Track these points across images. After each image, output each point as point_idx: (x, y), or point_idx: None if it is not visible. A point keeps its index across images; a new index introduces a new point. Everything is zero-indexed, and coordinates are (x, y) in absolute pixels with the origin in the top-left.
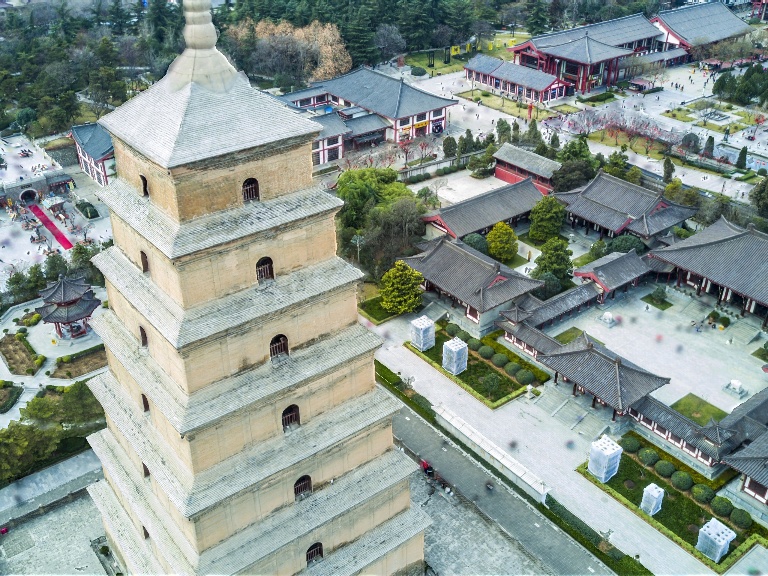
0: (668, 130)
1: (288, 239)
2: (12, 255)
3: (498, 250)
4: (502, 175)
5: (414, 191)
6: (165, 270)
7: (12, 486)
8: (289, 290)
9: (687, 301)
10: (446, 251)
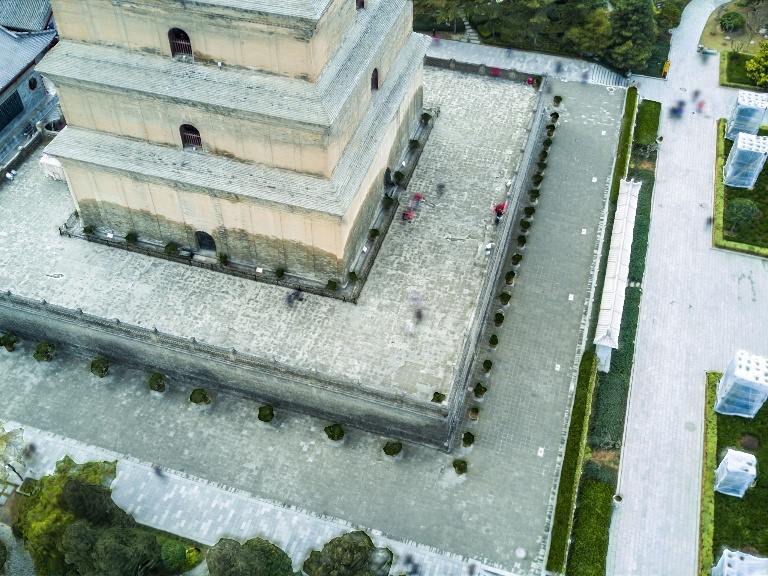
0: None
1: None
2: None
3: None
4: None
5: None
6: None
7: None
8: None
9: None
10: None
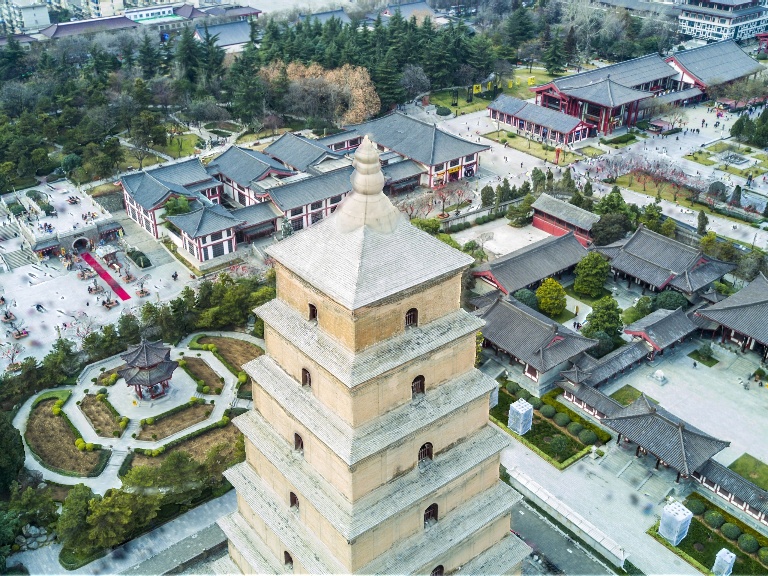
0: (692, 174)
1: (439, 358)
2: (72, 306)
3: (548, 306)
4: (540, 224)
5: (458, 242)
6: (334, 391)
7: (116, 552)
8: (438, 403)
9: (732, 358)
10: (502, 310)
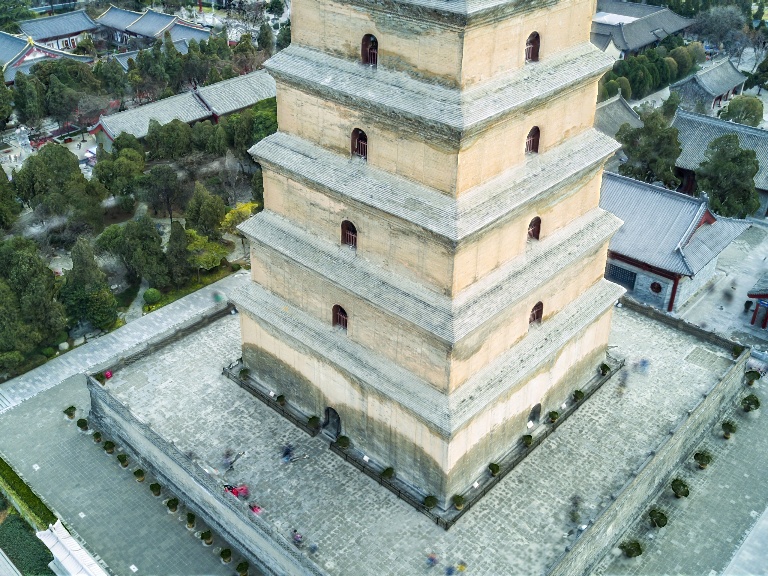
0: None
1: None
2: None
3: None
4: None
5: None
6: None
7: None
8: None
9: None
10: None
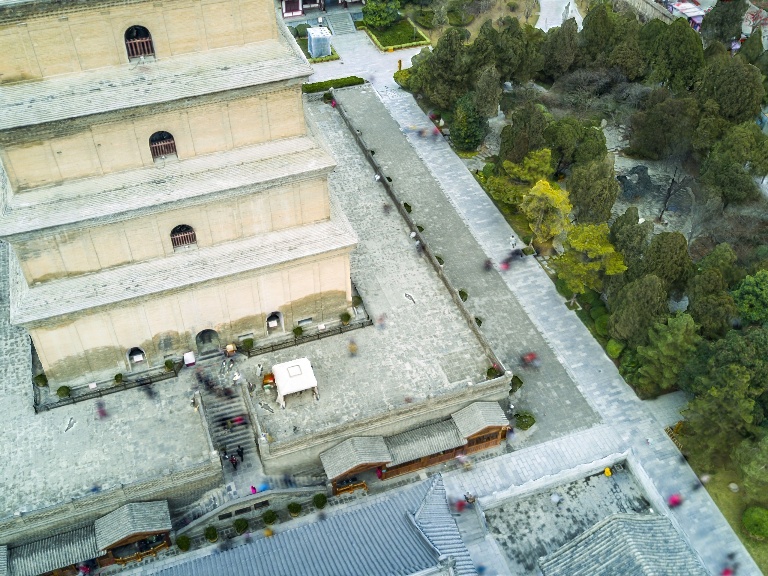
0: None
1: None
2: None
3: None
4: None
5: None
6: None
7: None
8: None
9: None
10: None
